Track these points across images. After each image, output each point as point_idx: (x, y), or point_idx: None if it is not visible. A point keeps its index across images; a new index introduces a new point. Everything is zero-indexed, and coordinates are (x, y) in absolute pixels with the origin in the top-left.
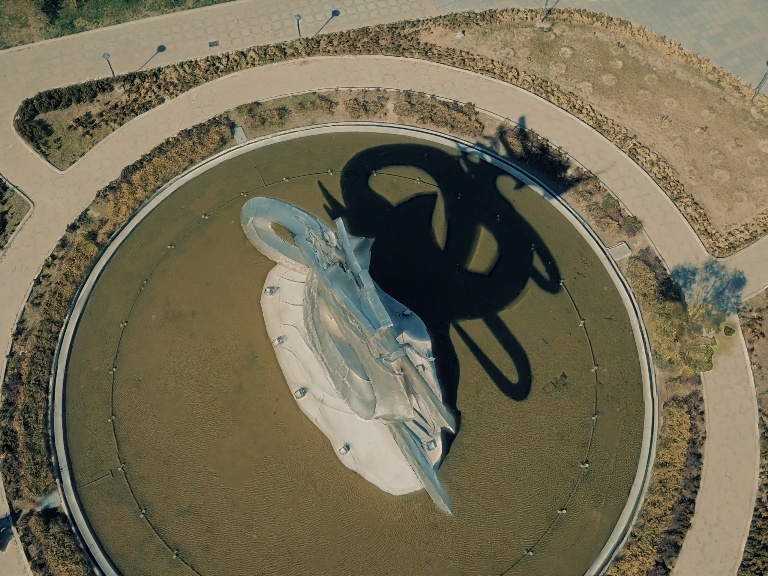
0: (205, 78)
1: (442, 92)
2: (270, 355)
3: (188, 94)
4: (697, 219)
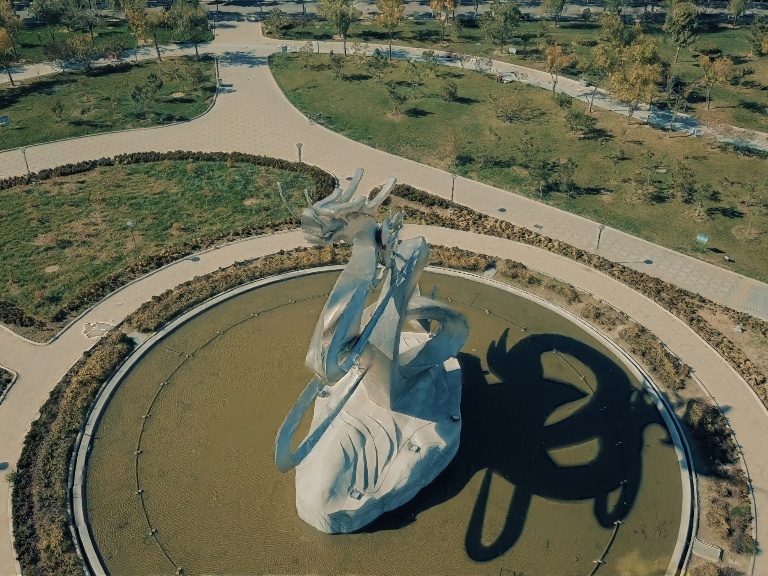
0: (508, 235)
1: (675, 347)
2: None
3: (488, 237)
4: None
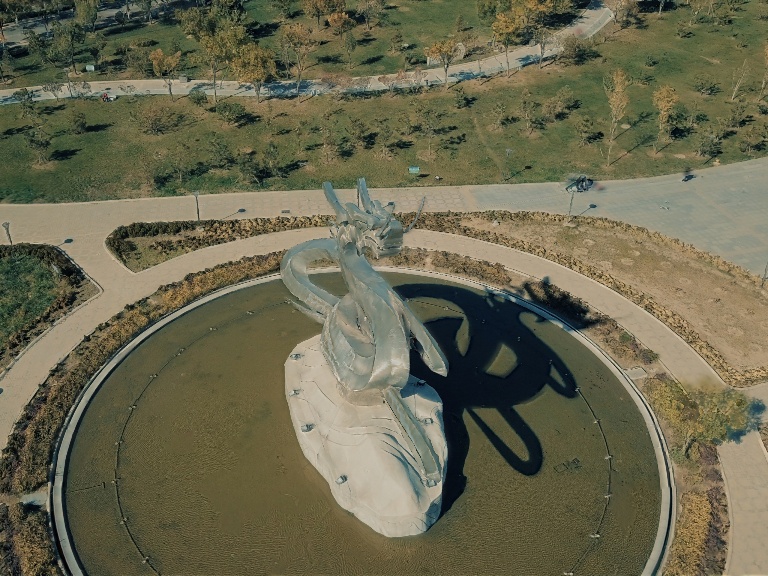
0: (273, 229)
1: (476, 255)
2: (284, 419)
3: (256, 238)
4: (713, 358)
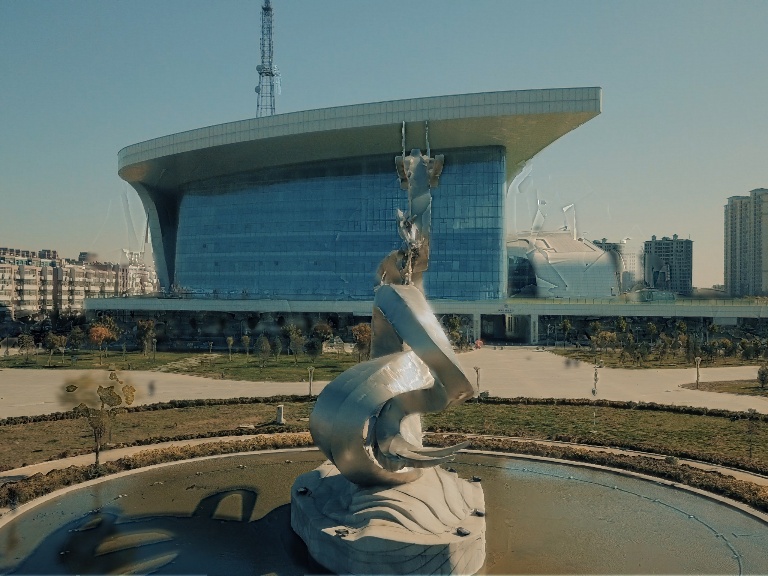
0: None
1: None
2: (493, 572)
3: None
4: None
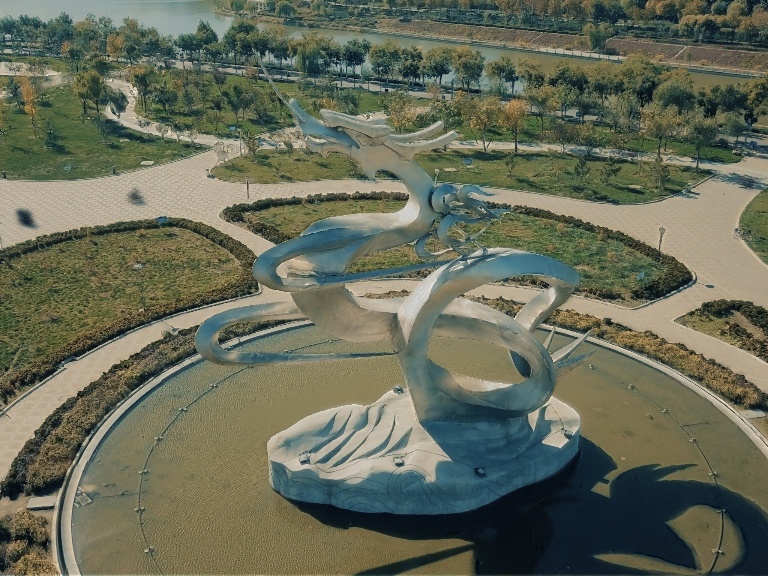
0: None
1: None
2: None
3: None
4: None
